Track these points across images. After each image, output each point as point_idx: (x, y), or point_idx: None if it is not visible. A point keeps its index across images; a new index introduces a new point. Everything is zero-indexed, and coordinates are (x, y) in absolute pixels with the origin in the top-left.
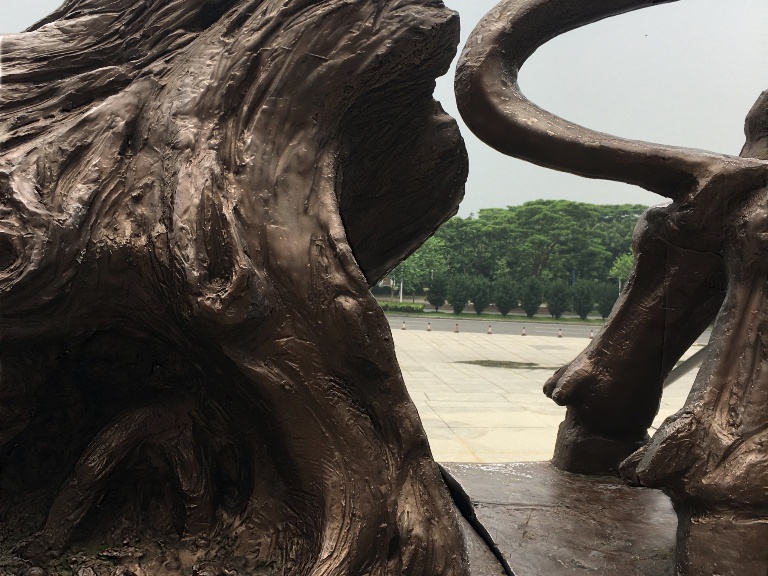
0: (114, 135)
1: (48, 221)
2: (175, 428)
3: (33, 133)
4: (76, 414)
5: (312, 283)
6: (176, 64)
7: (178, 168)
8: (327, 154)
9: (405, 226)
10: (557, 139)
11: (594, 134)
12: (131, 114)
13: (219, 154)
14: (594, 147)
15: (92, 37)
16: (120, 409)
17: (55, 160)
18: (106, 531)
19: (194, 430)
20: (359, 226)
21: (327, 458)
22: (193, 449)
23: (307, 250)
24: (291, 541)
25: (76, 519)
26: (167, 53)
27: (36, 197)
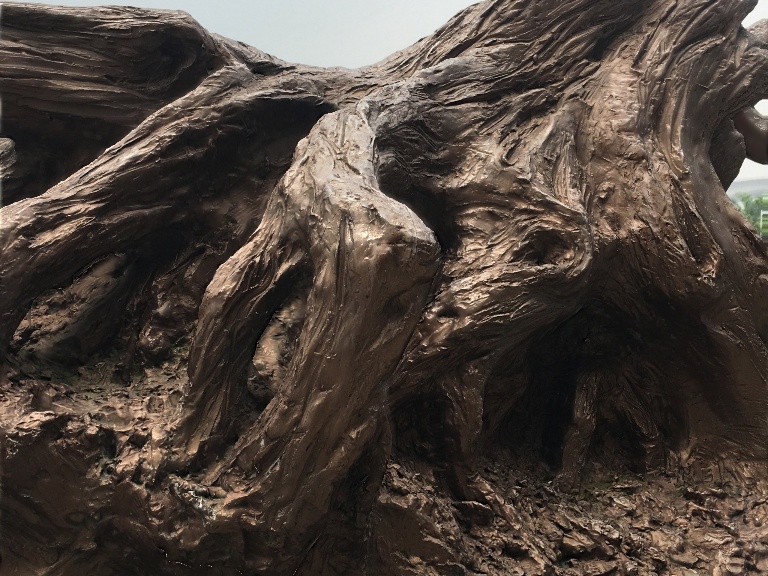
0: (571, 147)
1: (585, 219)
2: (616, 386)
3: (514, 145)
4: (529, 381)
5: None
6: (592, 89)
7: (641, 175)
8: (709, 164)
9: None
10: None
11: None
12: (574, 130)
13: None
14: None
15: (514, 63)
16: (576, 373)
17: (546, 168)
18: (588, 472)
19: (631, 387)
20: None
21: (767, 398)
22: (639, 402)
23: (732, 239)
24: (738, 465)
25: (582, 462)
26: (579, 79)
27: None
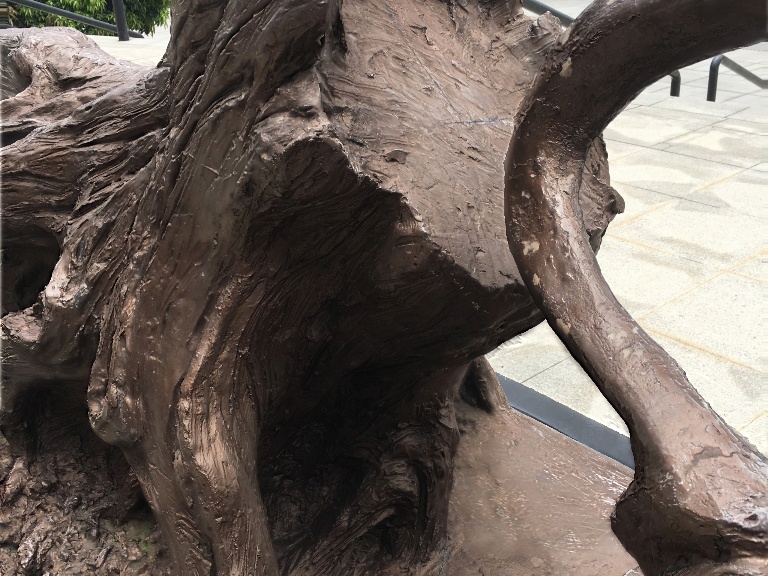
0: (128, 214)
1: (51, 304)
2: None
3: (100, 199)
4: None
5: (171, 424)
6: None
7: None
8: (231, 278)
9: (414, 333)
10: (538, 294)
11: (587, 303)
12: None
13: (139, 268)
14: (564, 331)
15: (158, 93)
16: None
17: (92, 234)
18: None
19: None
20: (339, 331)
21: None
22: None
23: (173, 390)
24: None
25: (128, 506)
26: None
27: (67, 272)
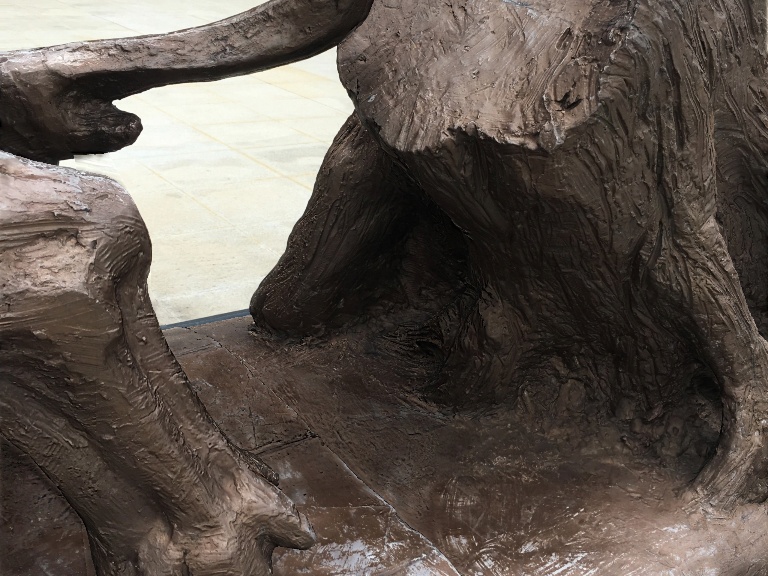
0: None
1: None
2: None
3: None
4: None
5: None
6: None
7: None
8: None
9: None
10: None
11: (204, 30)
12: None
13: None
14: None
15: None
16: None
17: None
18: None
19: None
20: None
21: None
22: None
23: None
24: None
25: None
26: None
27: None
